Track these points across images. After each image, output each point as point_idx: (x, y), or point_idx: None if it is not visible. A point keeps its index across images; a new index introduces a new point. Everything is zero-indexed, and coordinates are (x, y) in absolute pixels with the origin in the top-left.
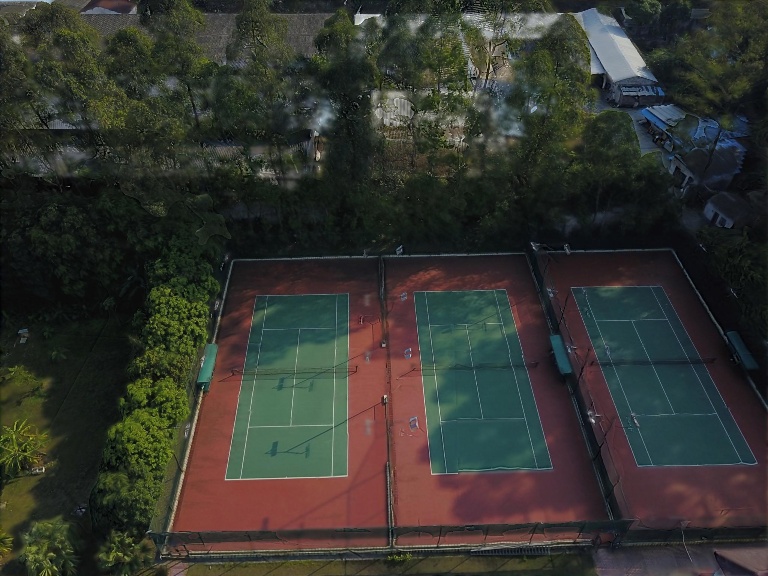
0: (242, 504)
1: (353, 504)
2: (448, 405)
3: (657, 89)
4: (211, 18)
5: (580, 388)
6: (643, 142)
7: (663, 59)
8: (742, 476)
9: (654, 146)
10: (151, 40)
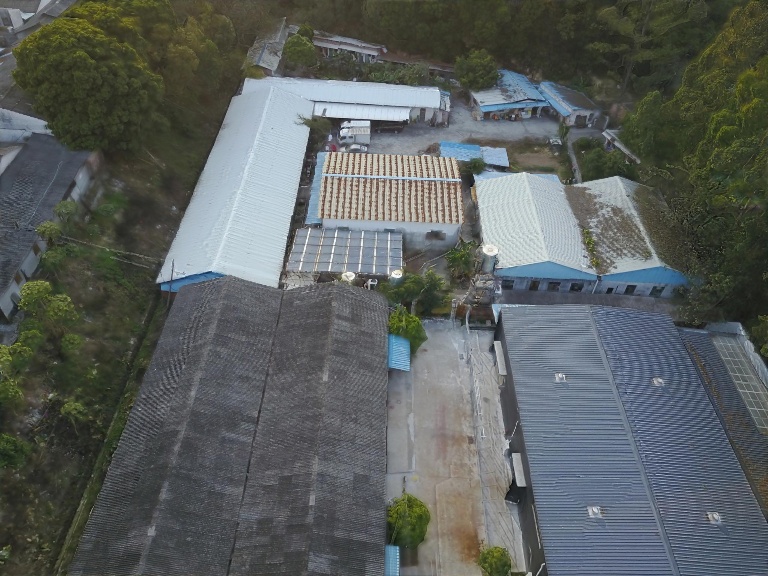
0: None
1: None
2: None
3: (443, 93)
4: (173, 520)
5: None
6: (515, 126)
7: (420, 69)
8: None
9: (520, 123)
10: None
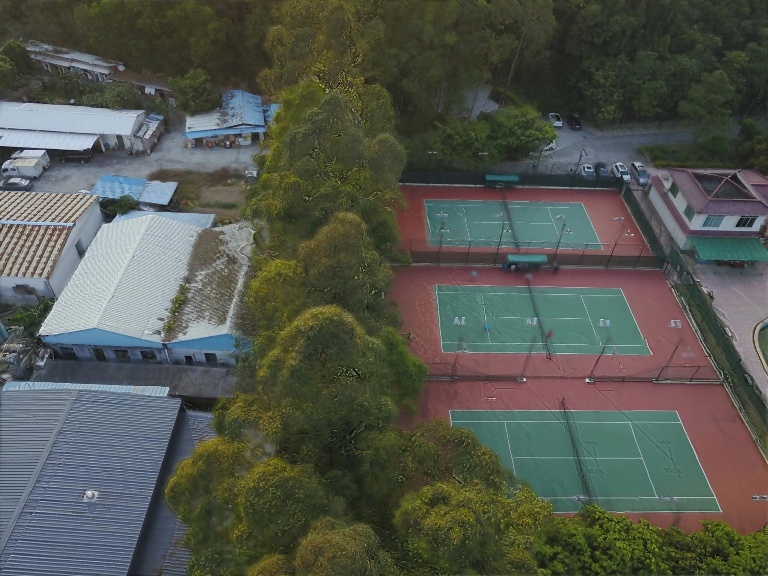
0: (739, 492)
1: (700, 407)
2: (583, 338)
3: (152, 117)
4: None
5: (563, 253)
6: (227, 154)
7: (123, 91)
8: (594, 211)
9: (236, 150)
10: (283, 448)
